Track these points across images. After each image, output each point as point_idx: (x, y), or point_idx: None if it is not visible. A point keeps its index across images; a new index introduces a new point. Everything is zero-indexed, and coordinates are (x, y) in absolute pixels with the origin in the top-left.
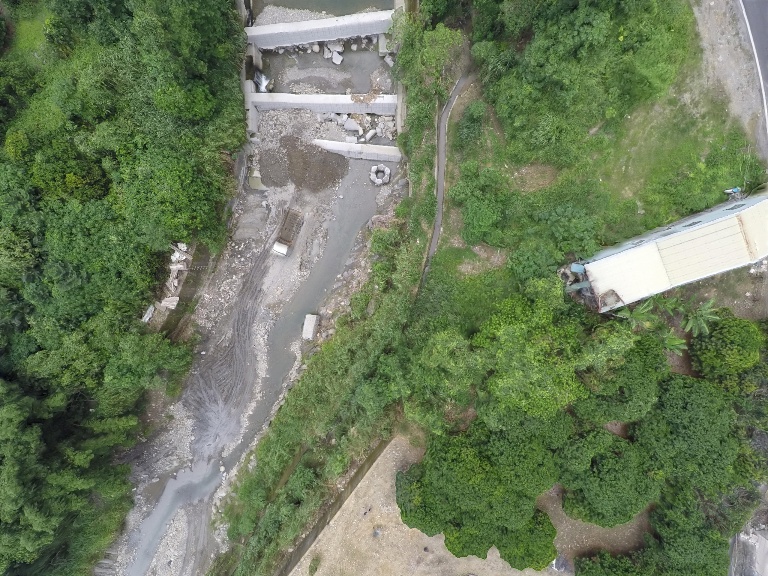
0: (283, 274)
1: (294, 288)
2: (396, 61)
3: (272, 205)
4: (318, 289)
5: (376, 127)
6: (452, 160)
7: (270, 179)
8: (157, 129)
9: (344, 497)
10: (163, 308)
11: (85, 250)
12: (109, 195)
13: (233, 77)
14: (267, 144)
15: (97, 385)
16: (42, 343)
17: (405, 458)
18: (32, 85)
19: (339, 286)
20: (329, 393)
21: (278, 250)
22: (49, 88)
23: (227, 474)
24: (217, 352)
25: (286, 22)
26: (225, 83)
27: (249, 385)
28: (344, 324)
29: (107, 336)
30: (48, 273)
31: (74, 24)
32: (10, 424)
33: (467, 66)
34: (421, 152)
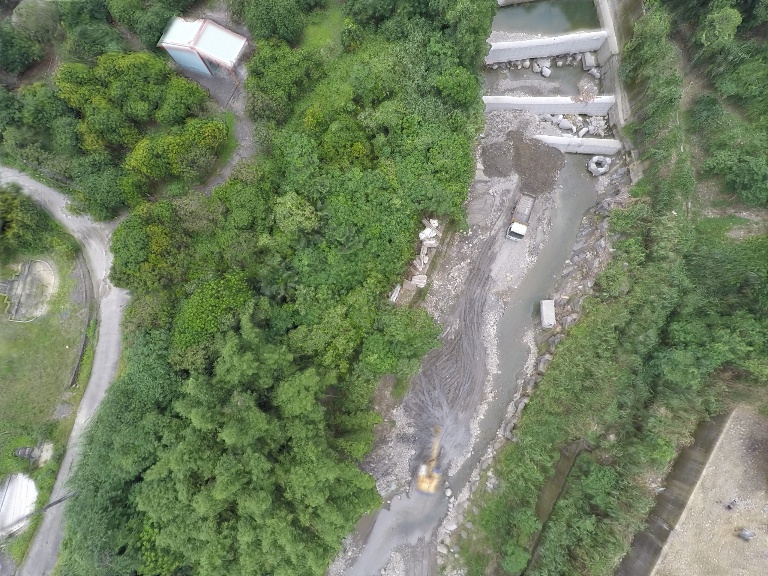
0: (511, 260)
1: (522, 275)
2: (627, 62)
3: (496, 194)
4: (546, 276)
5: (588, 126)
6: (688, 142)
7: (496, 169)
8: (425, 111)
9: (678, 494)
10: (413, 286)
11: (368, 214)
12: (381, 167)
13: (481, 75)
14: (491, 139)
15: (347, 370)
16: (298, 319)
17: (752, 434)
18: (321, 71)
19: (571, 271)
20: (596, 380)
21: (517, 231)
22: (334, 75)
23: (455, 499)
24: (442, 346)
25: (509, 41)
26: (478, 78)
27: (479, 383)
28: (597, 304)
29: (364, 312)
30: (335, 234)
31: (367, 24)
32: (308, 394)
33: (683, 69)
34: (669, 131)
